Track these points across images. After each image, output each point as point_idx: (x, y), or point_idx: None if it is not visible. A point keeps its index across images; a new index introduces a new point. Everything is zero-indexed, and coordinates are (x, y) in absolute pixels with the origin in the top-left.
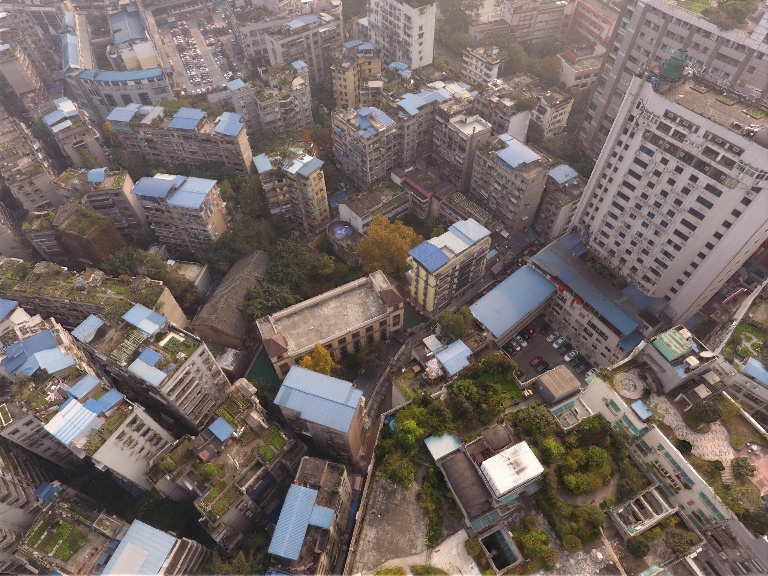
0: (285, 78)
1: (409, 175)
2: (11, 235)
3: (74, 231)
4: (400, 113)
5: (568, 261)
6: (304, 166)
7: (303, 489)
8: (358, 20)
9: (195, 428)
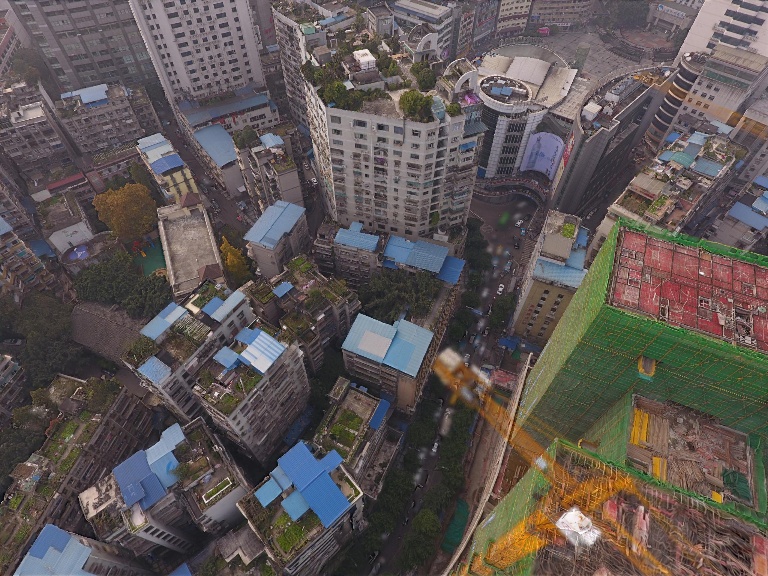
0: None
1: None
2: None
3: None
4: None
5: (203, 110)
6: None
7: (338, 234)
8: None
9: None
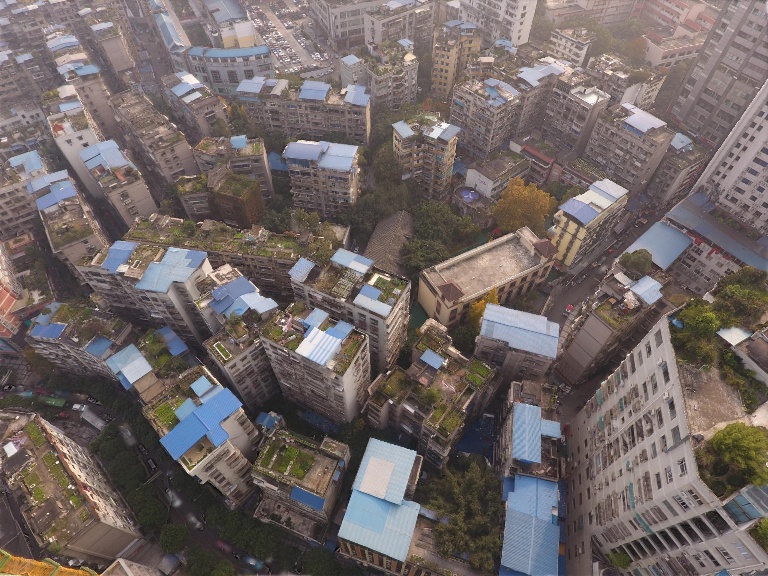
0: (396, 54)
1: (527, 144)
2: (152, 200)
3: (228, 193)
4: (521, 85)
5: (701, 216)
6: (444, 132)
7: (528, 406)
8: (447, 2)
9: (380, 368)
